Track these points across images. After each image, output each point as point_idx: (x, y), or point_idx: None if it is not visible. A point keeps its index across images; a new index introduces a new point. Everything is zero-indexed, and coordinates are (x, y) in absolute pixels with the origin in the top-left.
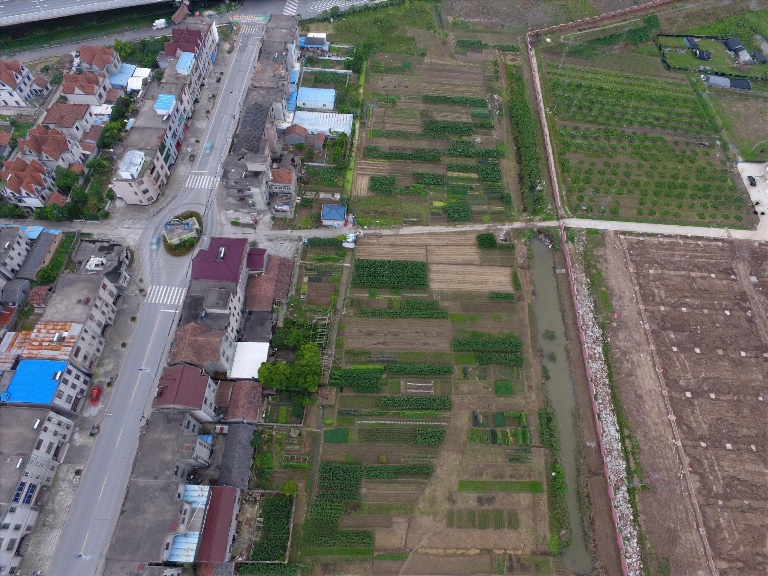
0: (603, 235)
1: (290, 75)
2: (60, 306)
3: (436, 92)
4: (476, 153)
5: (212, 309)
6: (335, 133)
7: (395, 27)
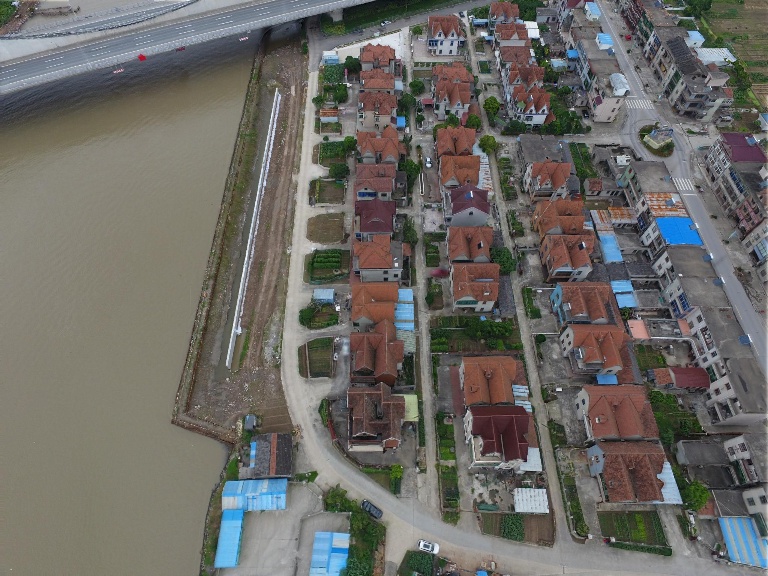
0: None
1: None
2: (650, 183)
3: None
4: None
5: None
6: (730, 61)
7: None
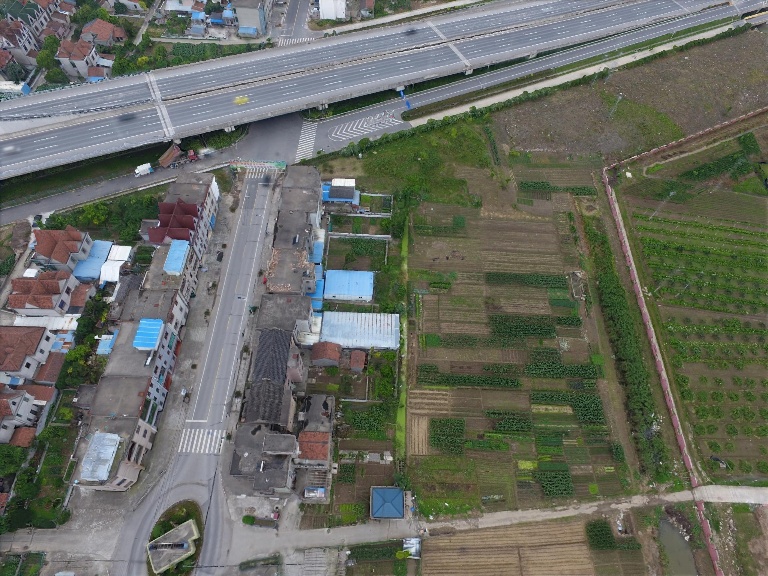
0: (755, 514)
1: (314, 251)
2: None
3: (501, 265)
4: (566, 372)
5: None
6: (380, 354)
7: (440, 165)
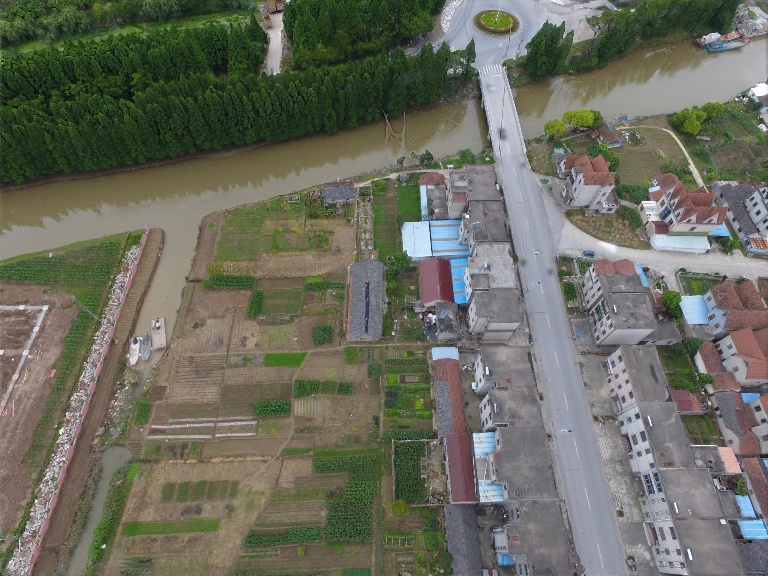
0: None
1: None
2: None
3: None
4: None
5: None
6: None
7: None
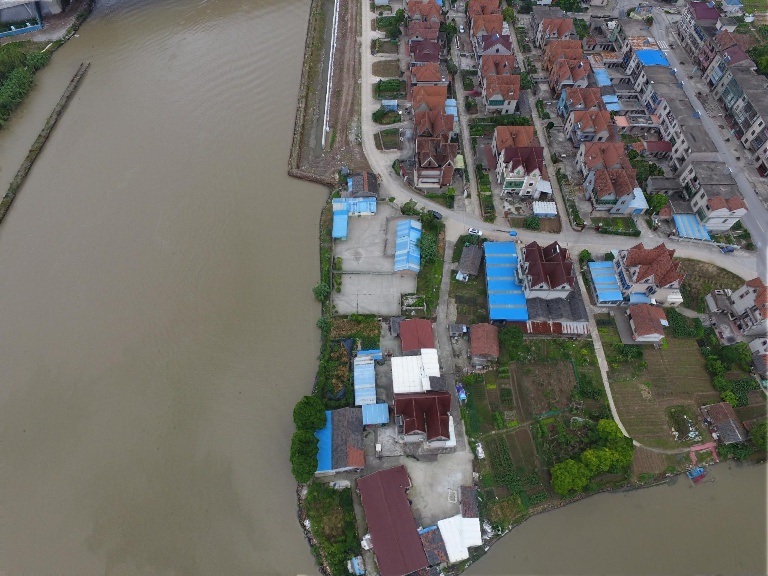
0: None
1: None
2: (632, 31)
3: None
4: None
5: (729, 26)
6: None
7: None
